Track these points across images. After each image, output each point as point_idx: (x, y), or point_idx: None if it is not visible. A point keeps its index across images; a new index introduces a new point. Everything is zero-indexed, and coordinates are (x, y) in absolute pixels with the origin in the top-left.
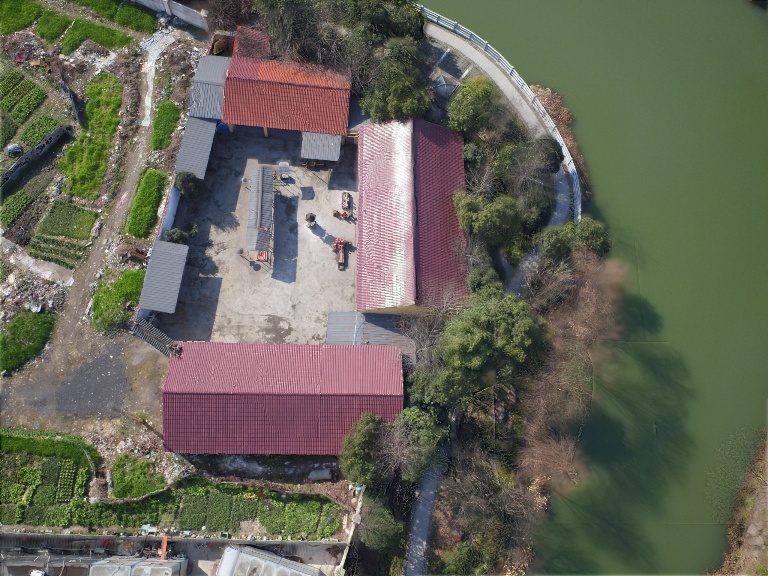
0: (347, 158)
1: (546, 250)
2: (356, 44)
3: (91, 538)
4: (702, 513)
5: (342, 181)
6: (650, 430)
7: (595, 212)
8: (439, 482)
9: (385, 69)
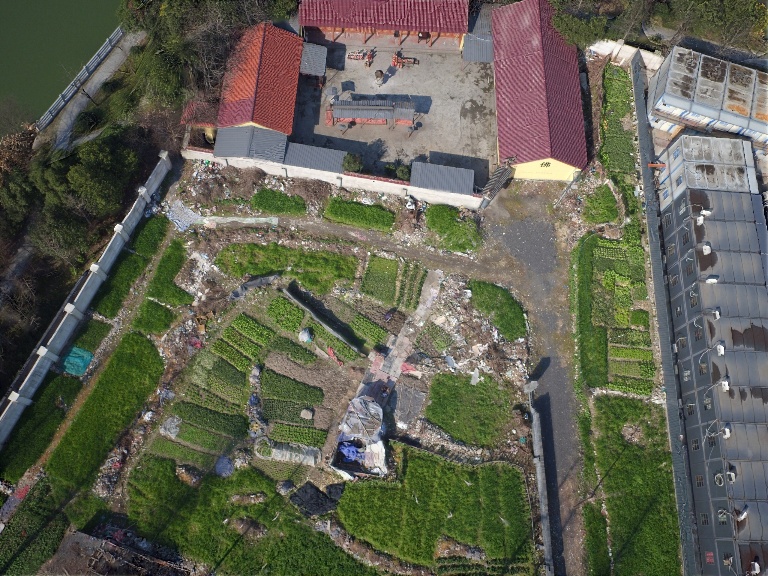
0: None
1: None
2: (223, 7)
3: None
4: None
5: (336, 60)
6: None
7: None
8: None
9: None
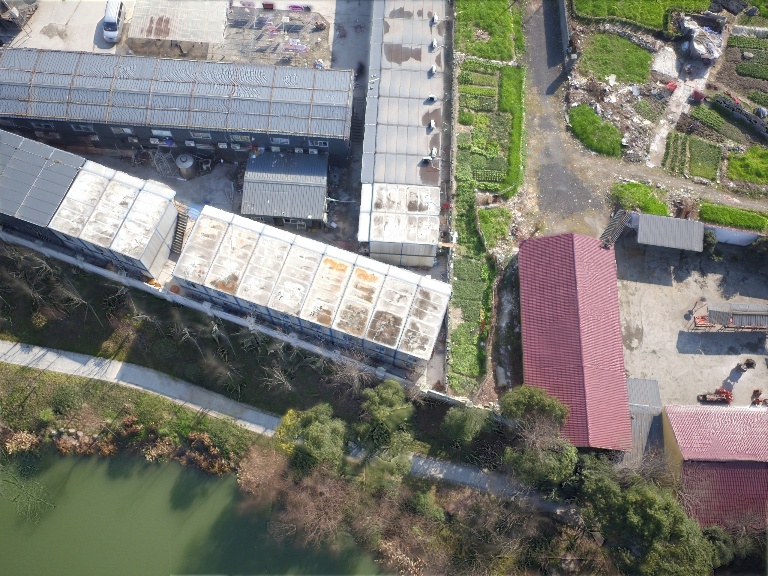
0: None
1: None
2: None
3: (449, 195)
4: None
5: None
6: None
7: None
8: (507, 482)
9: None
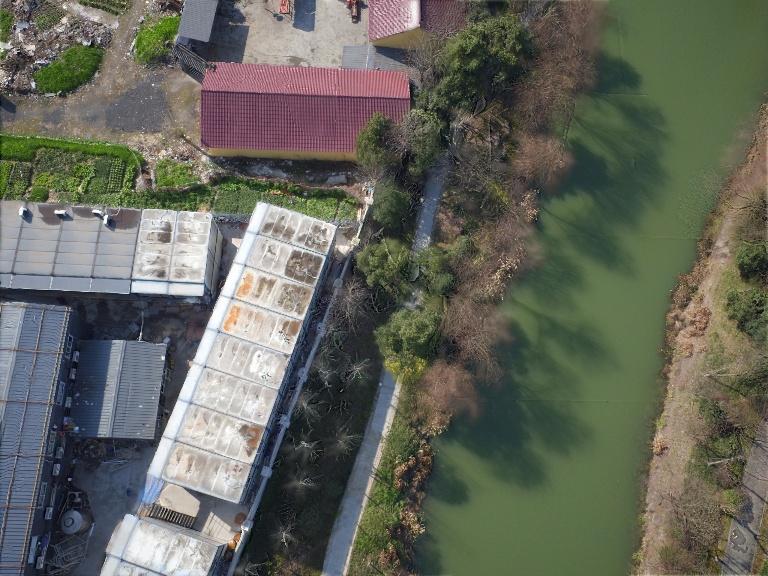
0: None
1: None
2: None
3: None
4: (675, 230)
5: None
6: (629, 164)
7: None
8: (441, 170)
9: None
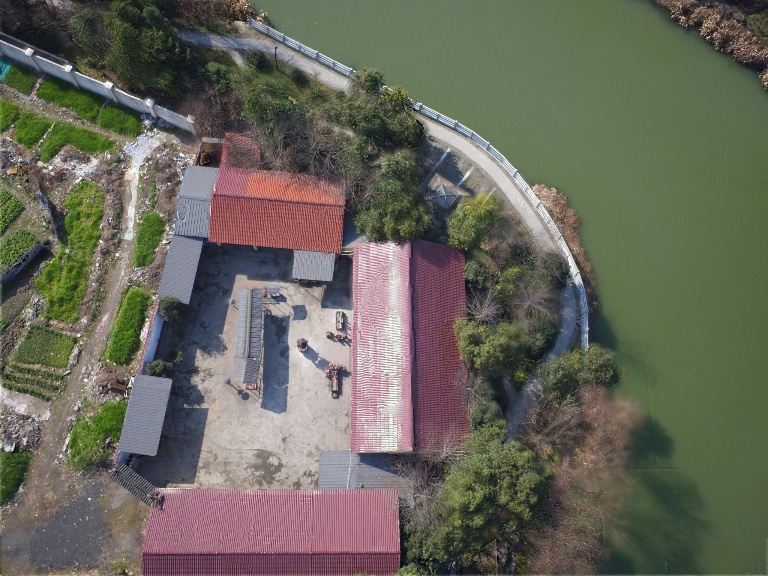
0: (341, 272)
1: (552, 383)
2: (351, 158)
3: None
4: None
5: (336, 298)
6: (662, 568)
7: (603, 325)
8: None
9: (381, 187)
